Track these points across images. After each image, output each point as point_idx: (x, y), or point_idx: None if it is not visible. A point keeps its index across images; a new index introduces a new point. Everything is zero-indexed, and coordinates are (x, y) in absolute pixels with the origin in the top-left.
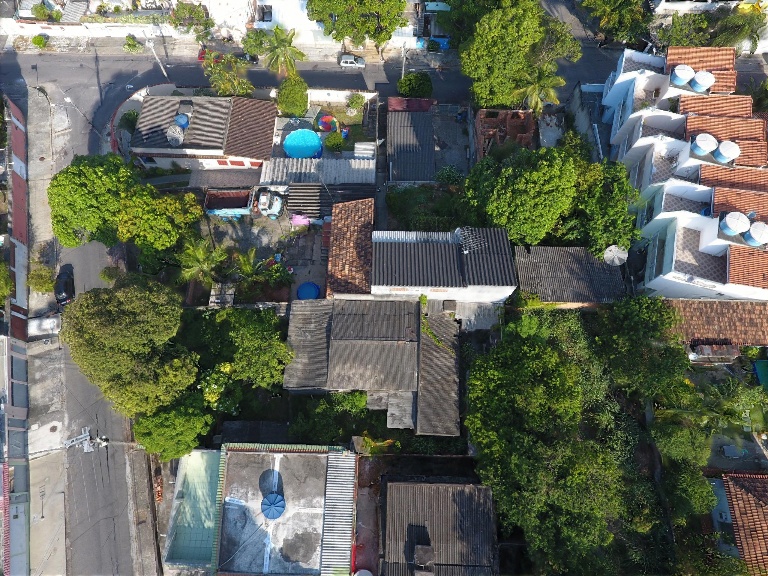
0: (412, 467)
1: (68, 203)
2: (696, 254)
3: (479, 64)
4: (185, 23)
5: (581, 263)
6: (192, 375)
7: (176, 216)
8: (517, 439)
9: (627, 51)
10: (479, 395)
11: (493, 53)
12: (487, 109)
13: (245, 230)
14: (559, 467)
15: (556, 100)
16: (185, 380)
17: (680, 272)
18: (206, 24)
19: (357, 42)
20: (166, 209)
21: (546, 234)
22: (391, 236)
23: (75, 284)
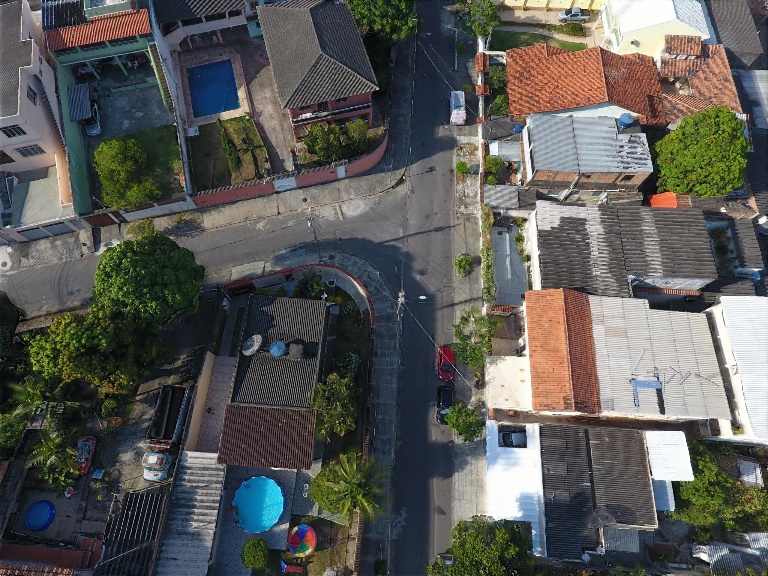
0: None
1: None
2: None
3: None
4: None
5: None
6: None
7: (63, 375)
8: None
9: None
10: None
11: None
12: None
13: None
14: None
15: None
16: None
17: None
18: (472, 357)
19: None
20: None
21: None
22: None
23: None
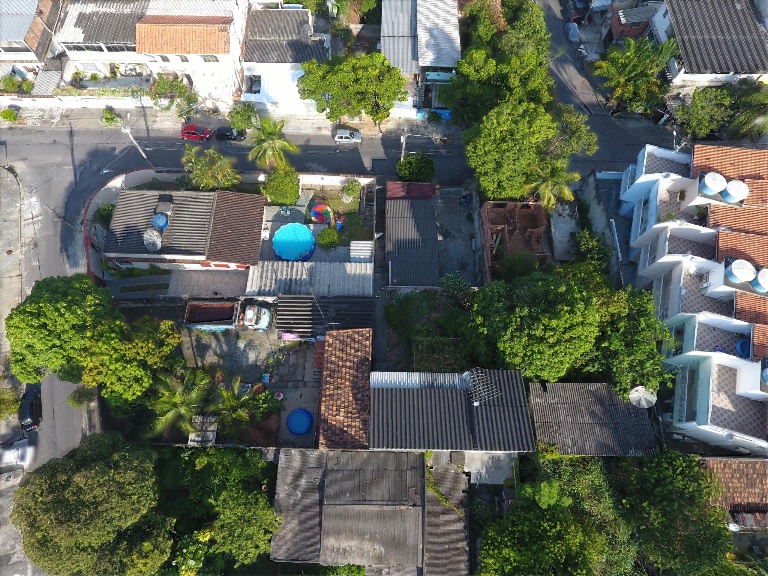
0: None
1: (26, 344)
2: (733, 397)
3: (486, 159)
4: (167, 95)
5: (604, 404)
6: (166, 552)
7: (149, 359)
8: None
9: (649, 147)
10: (492, 575)
11: (502, 149)
12: (494, 201)
13: (230, 344)
14: None
15: (570, 197)
16: (157, 562)
17: None
18: (189, 99)
19: (353, 115)
20: (137, 353)
21: None
22: (391, 379)
23: (43, 404)
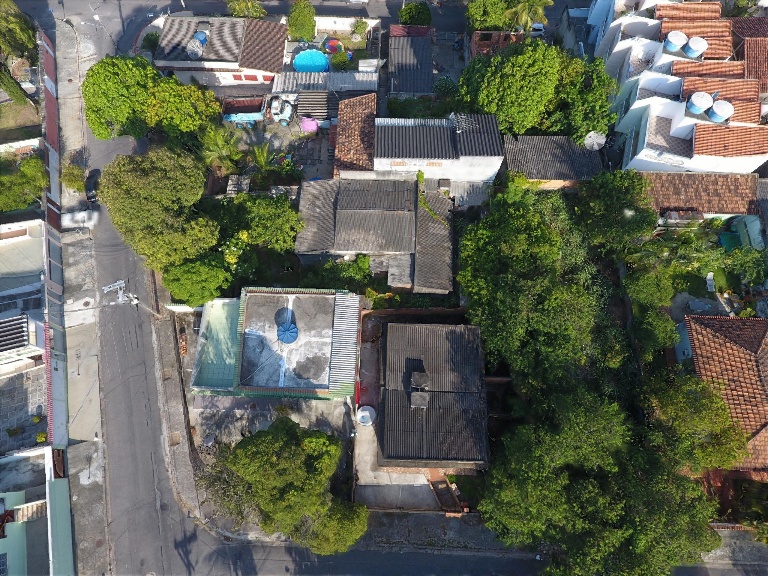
0: None
1: (102, 92)
2: (667, 138)
3: None
4: None
5: (564, 149)
6: (214, 237)
7: (199, 103)
8: (502, 279)
9: None
10: (470, 254)
11: None
12: (481, 31)
13: (258, 136)
14: (538, 296)
15: (545, 18)
16: (208, 239)
17: (651, 149)
18: None
19: None
20: (190, 96)
21: (533, 128)
22: (392, 122)
23: None
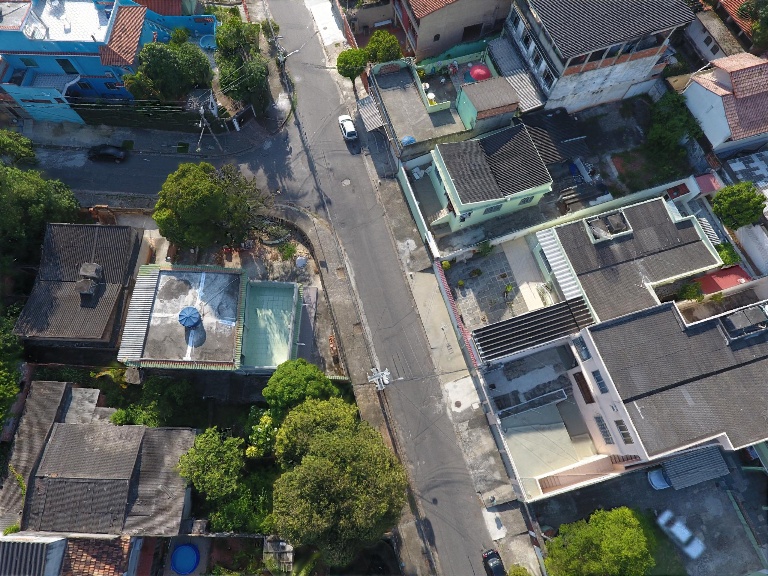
0: (101, 360)
1: None
2: None
3: None
4: None
5: None
6: None
7: None
8: None
9: None
10: None
11: None
12: None
13: None
14: None
15: None
16: None
17: None
18: None
19: None
20: None
21: None
22: None
23: None
